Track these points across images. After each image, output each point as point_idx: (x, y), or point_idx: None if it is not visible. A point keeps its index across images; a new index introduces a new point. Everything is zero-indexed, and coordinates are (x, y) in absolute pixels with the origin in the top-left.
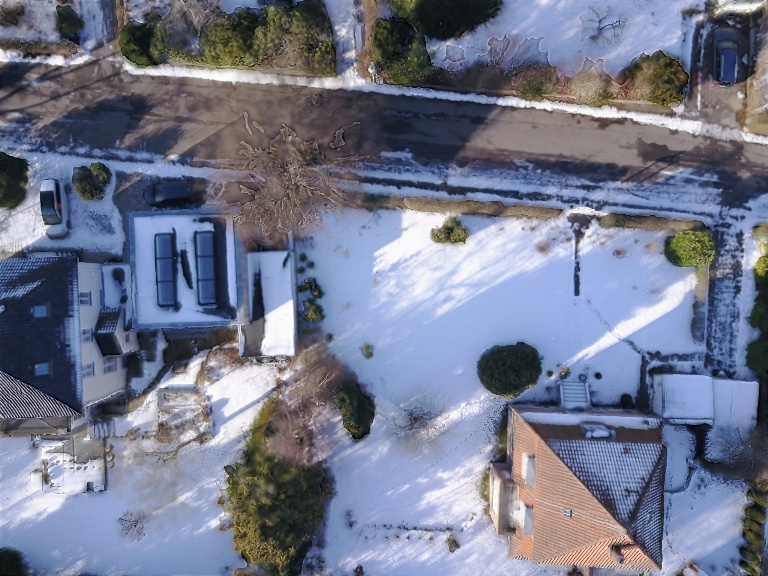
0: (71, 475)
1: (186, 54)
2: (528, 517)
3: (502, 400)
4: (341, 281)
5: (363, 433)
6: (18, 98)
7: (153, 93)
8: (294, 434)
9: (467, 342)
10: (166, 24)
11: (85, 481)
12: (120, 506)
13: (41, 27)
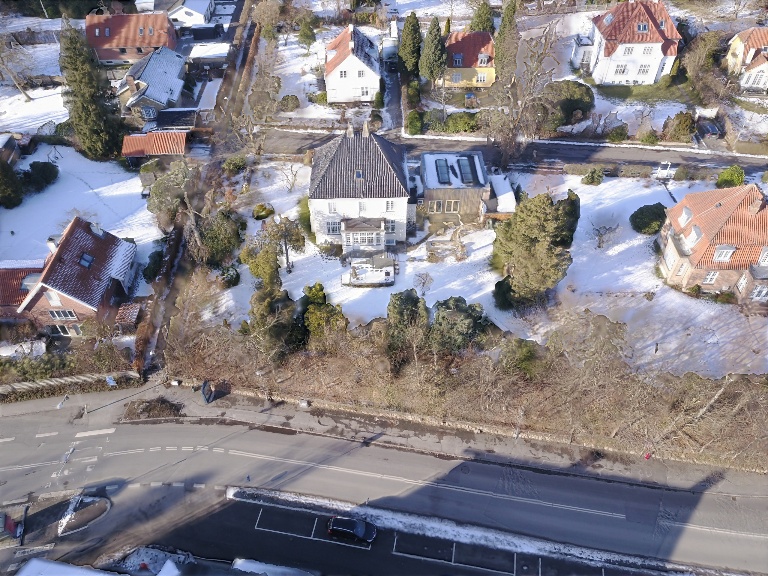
0: (371, 274)
1: (440, 123)
2: (695, 228)
3: (651, 238)
4: None
5: (578, 206)
6: None
7: (417, 143)
8: None
9: (619, 218)
10: (432, 111)
11: (381, 276)
12: None
13: (360, 124)
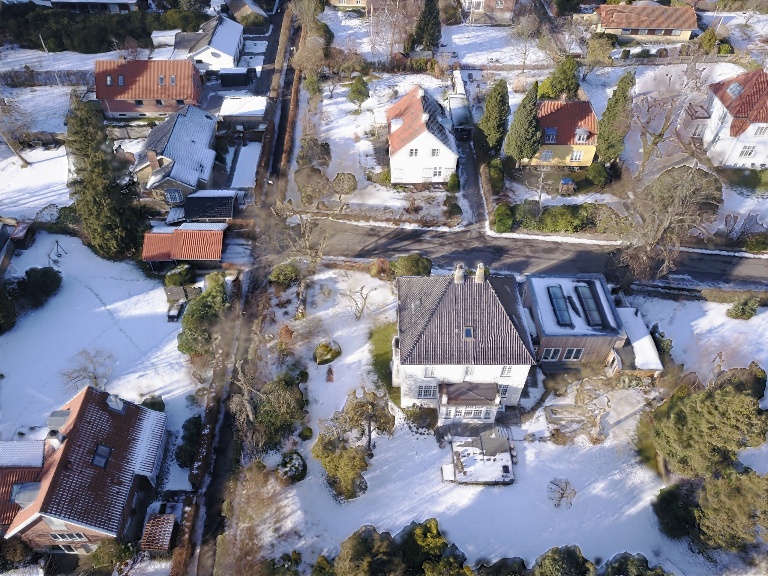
0: (482, 465)
1: (536, 221)
2: None
3: None
4: (673, 338)
5: (764, 385)
6: (418, 244)
7: (507, 245)
8: None
9: None
10: (526, 205)
11: (496, 470)
12: (529, 497)
13: (434, 215)
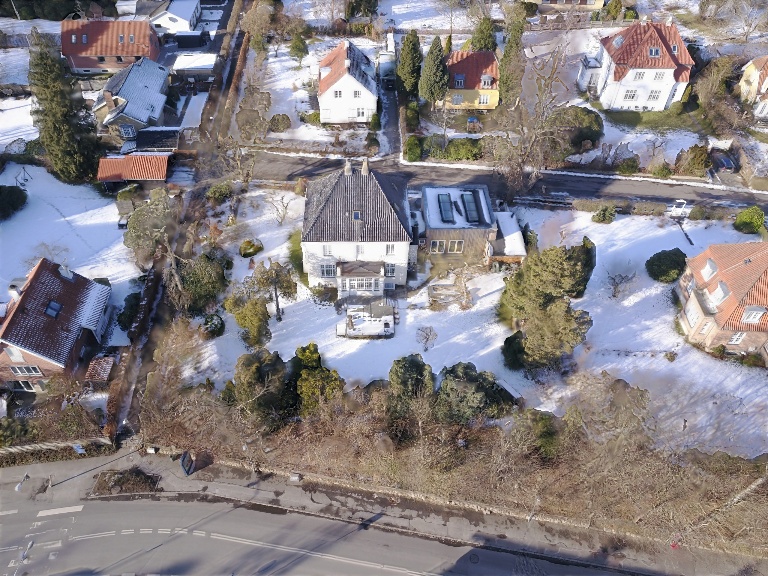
0: (369, 324)
1: (441, 150)
2: (722, 285)
3: (669, 287)
4: (543, 237)
5: (594, 255)
6: None
7: (417, 171)
8: None
9: (633, 263)
10: (433, 137)
11: (380, 327)
12: (405, 346)
13: (356, 148)
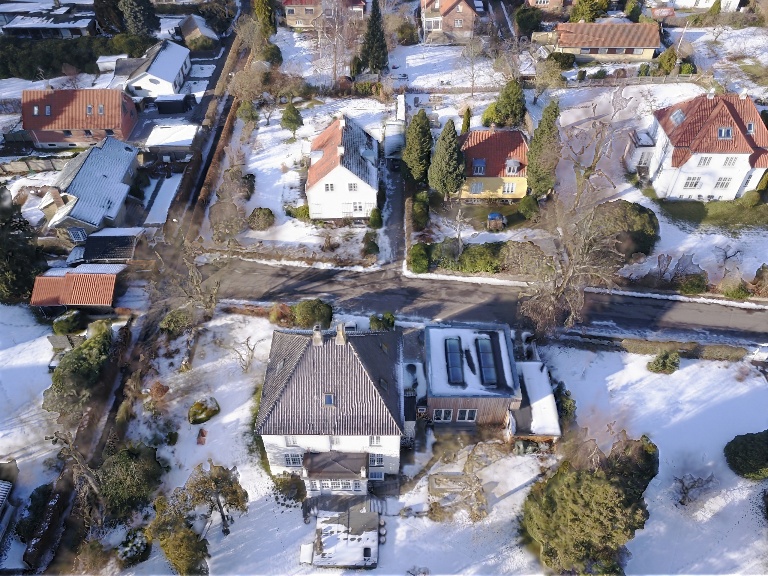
0: (344, 546)
1: (453, 261)
2: None
3: (759, 488)
4: (583, 396)
5: (657, 461)
6: (327, 286)
7: (423, 287)
8: (597, 454)
9: (706, 442)
10: (444, 244)
11: (358, 552)
12: None
13: (350, 253)
